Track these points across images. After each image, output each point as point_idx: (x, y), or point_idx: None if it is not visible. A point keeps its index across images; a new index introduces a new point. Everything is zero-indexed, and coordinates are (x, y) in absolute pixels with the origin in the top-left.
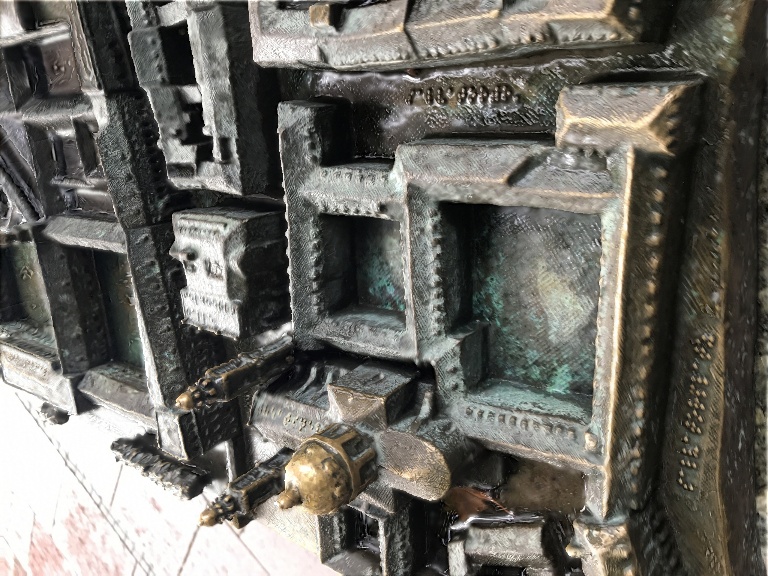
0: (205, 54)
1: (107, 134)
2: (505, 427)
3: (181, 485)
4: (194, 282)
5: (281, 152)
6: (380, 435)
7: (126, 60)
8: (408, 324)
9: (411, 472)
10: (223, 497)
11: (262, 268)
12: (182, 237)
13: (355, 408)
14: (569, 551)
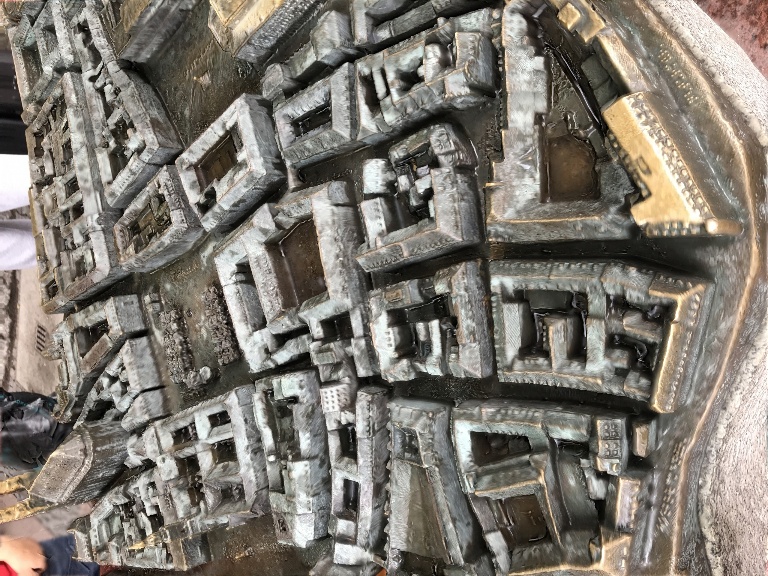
0: None
1: None
2: (23, 29)
3: None
4: None
5: (60, 51)
6: (14, 1)
7: None
8: (38, 32)
9: (5, 3)
10: None
11: None
12: None
13: (18, 2)
14: (3, 17)
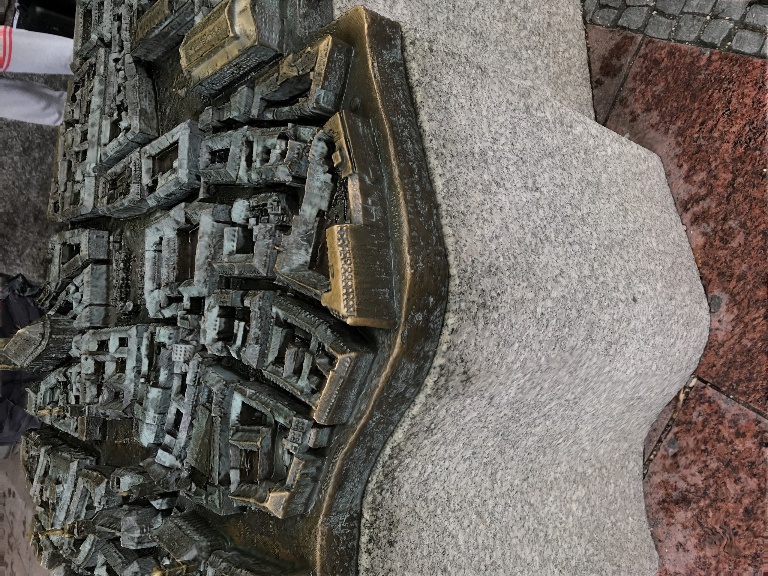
0: None
1: None
2: None
3: None
4: None
5: None
6: None
7: None
8: (95, 4)
9: None
10: None
11: None
12: None
13: None
14: None
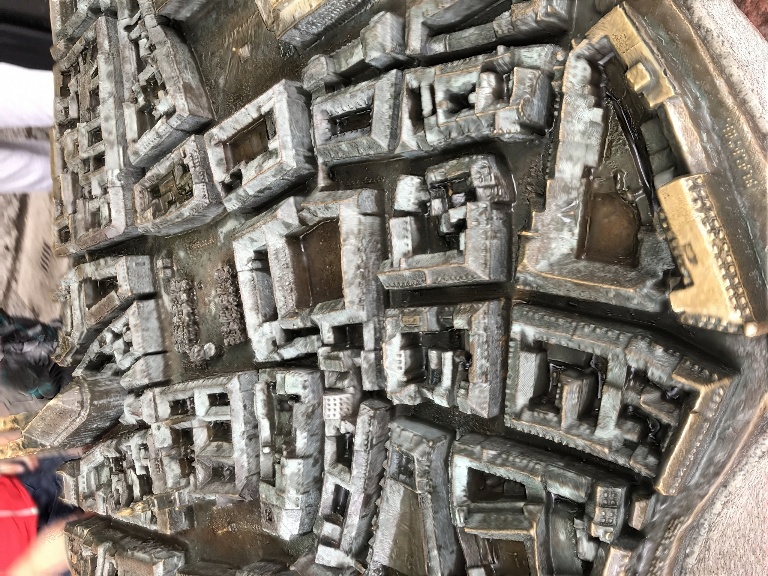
0: None
1: None
2: None
3: None
4: None
5: None
6: None
7: None
8: None
9: None
10: None
11: None
12: None
13: None
14: None
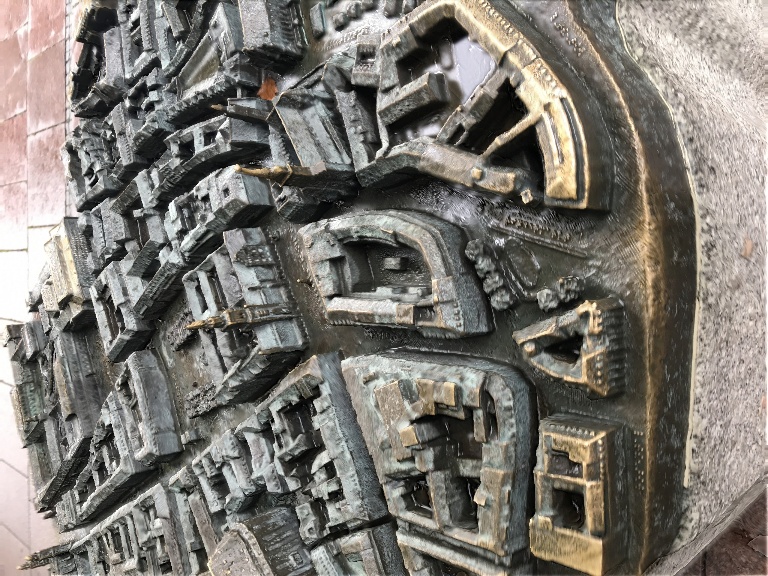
0: (89, 506)
1: (68, 461)
2: None
3: (37, 495)
4: (61, 510)
5: None
6: None
7: (86, 452)
8: None
9: None
10: (26, 567)
11: (77, 527)
12: (65, 503)
13: None
14: None
